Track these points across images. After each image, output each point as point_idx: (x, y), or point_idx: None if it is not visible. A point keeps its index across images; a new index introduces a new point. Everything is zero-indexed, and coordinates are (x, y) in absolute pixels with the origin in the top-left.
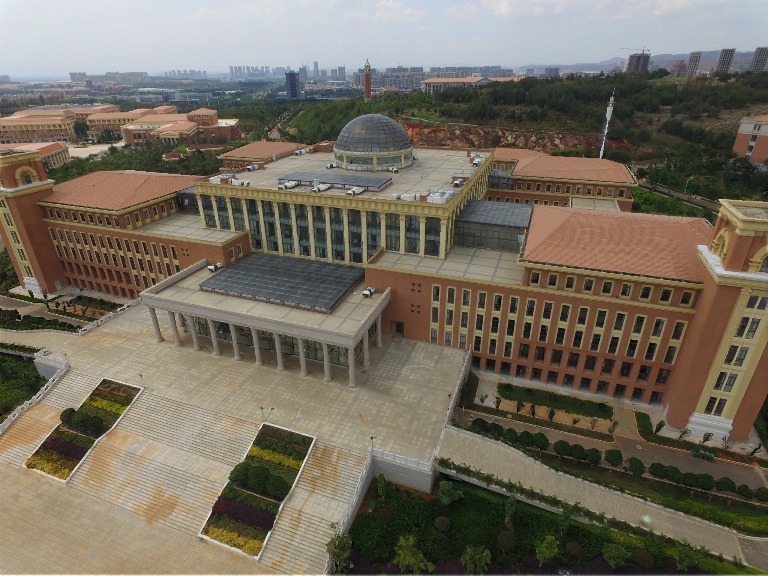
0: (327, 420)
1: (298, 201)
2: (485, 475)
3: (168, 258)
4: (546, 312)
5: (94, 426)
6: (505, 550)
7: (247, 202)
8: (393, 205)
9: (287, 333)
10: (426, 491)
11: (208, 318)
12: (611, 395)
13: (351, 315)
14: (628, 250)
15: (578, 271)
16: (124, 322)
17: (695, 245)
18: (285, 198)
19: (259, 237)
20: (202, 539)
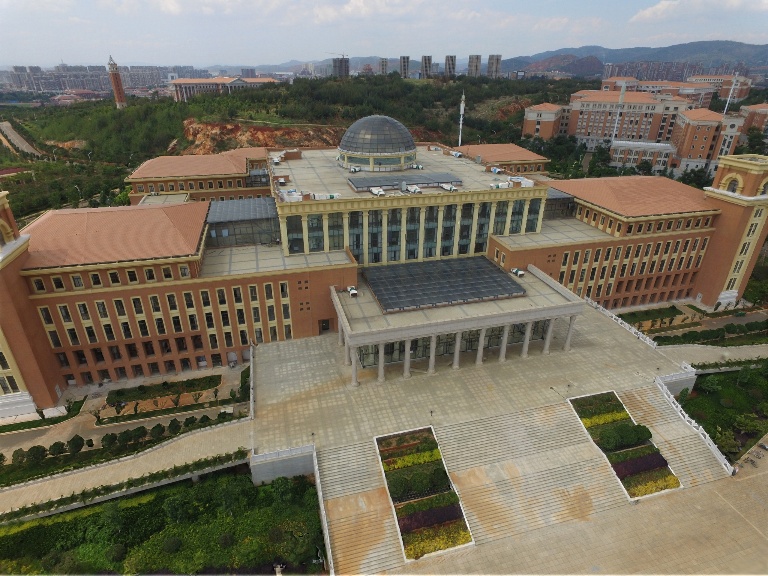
0: (596, 377)
1: (413, 204)
2: (714, 364)
3: (274, 299)
4: (637, 253)
5: (446, 478)
6: (760, 400)
7: (349, 215)
8: (504, 193)
9: (524, 320)
10: (689, 393)
11: (437, 334)
12: (666, 300)
13: (540, 292)
14: (665, 198)
15: (662, 217)
16: (277, 386)
17: (686, 189)
18: (398, 204)
19: (359, 251)
20: (638, 501)
